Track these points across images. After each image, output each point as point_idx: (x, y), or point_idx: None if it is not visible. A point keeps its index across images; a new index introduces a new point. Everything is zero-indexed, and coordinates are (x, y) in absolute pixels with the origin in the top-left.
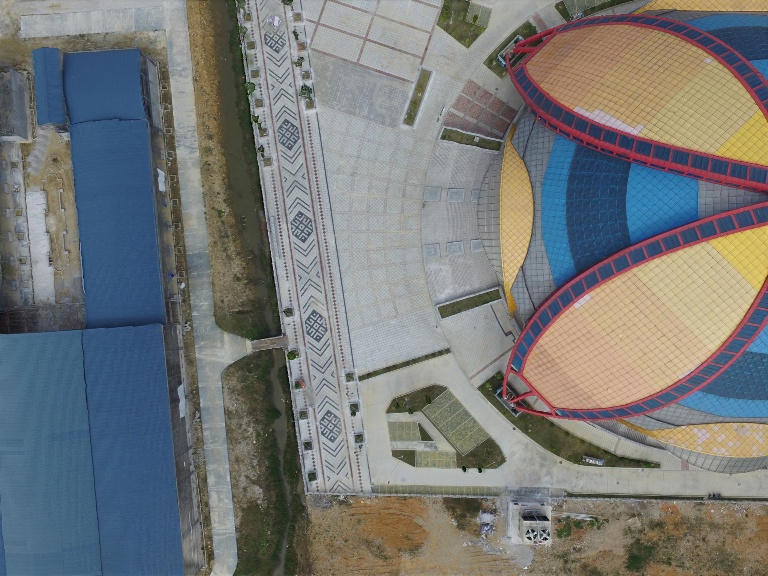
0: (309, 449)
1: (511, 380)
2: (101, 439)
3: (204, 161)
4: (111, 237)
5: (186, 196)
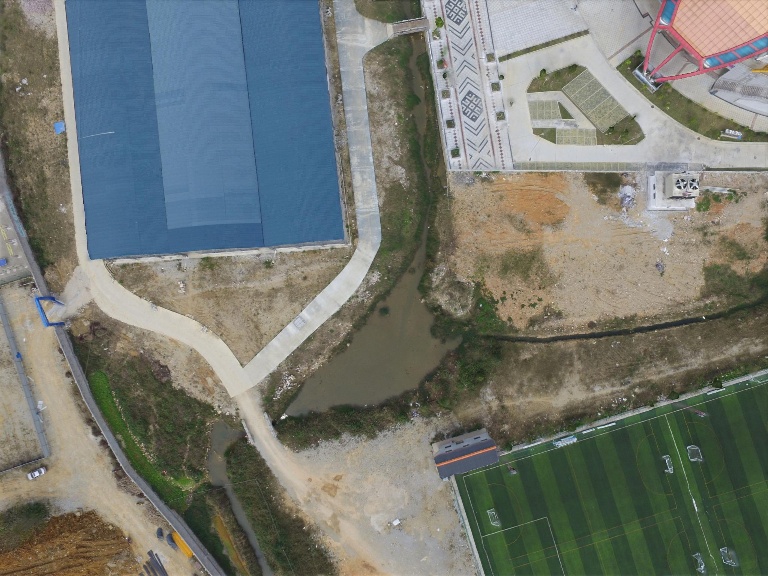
0: (452, 126)
1: (649, 60)
2: (259, 92)
3: None
4: None
5: None
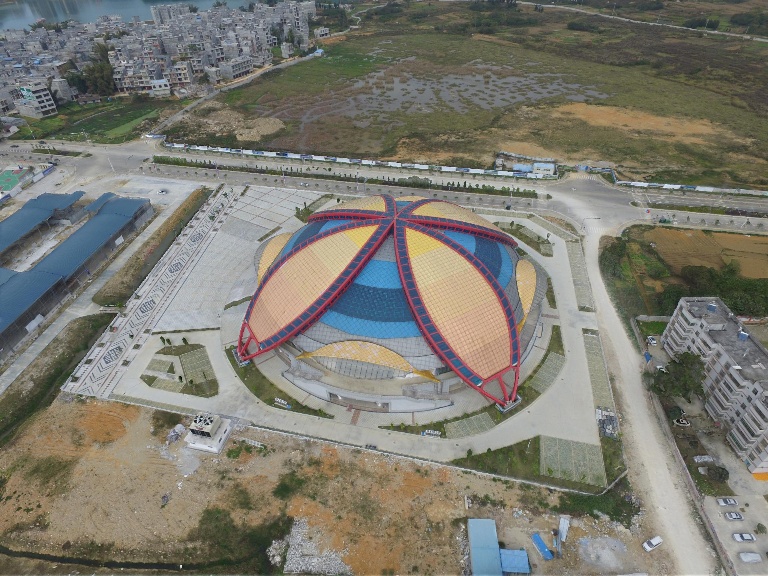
0: (88, 363)
1: (250, 349)
2: None
3: (148, 241)
4: None
5: (127, 251)
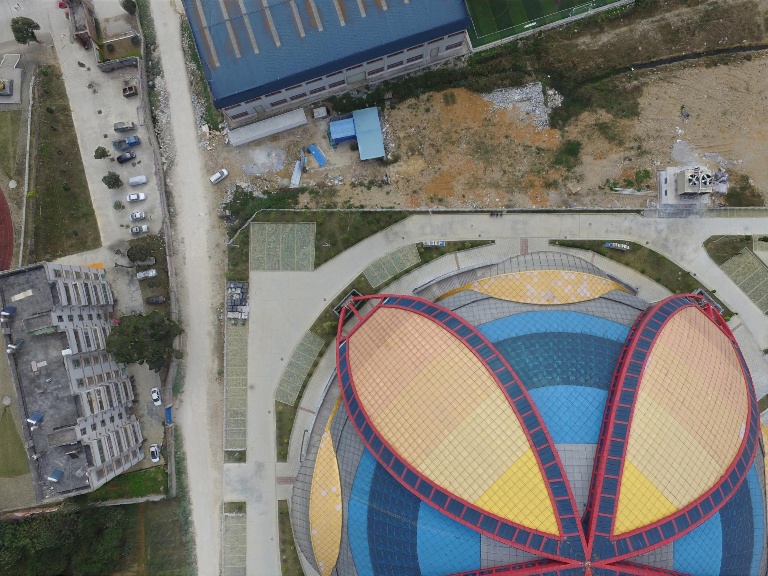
0: None
1: None
2: None
3: None
4: None
5: None
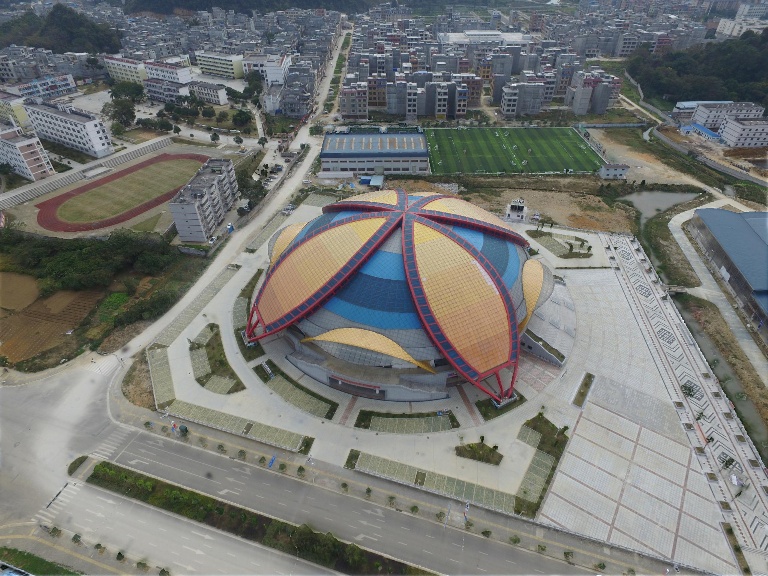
0: None
1: None
2: None
3: (764, 390)
4: None
5: None
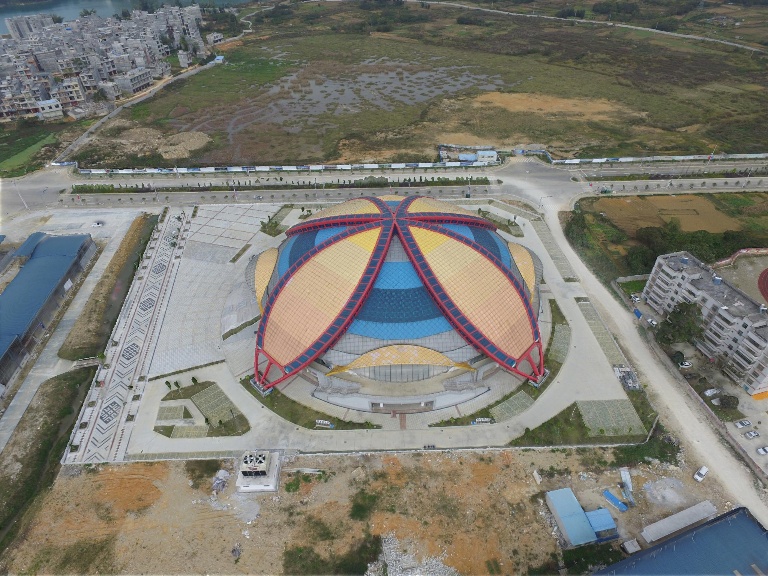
0: (83, 427)
1: (267, 376)
2: None
3: (101, 281)
4: (16, 298)
5: (80, 295)
